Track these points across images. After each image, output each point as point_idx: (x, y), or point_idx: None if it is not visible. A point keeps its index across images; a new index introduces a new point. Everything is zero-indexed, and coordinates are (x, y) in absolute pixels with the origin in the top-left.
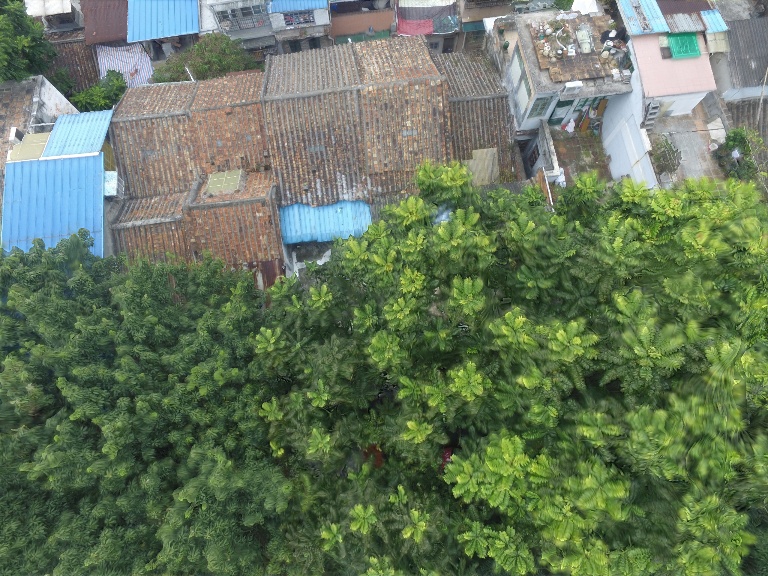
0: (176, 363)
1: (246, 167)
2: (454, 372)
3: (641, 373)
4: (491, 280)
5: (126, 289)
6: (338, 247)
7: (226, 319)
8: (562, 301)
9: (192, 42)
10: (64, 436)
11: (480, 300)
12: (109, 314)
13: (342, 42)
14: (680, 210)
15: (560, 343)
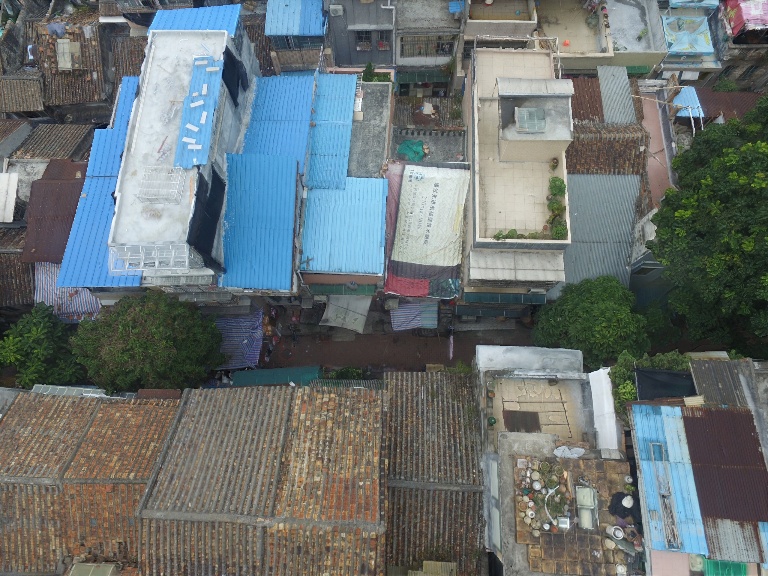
0: None
1: (123, 555)
2: None
3: None
4: None
5: None
6: None
7: None
8: None
9: None
10: None
11: None
12: None
13: (317, 292)
14: None
15: None
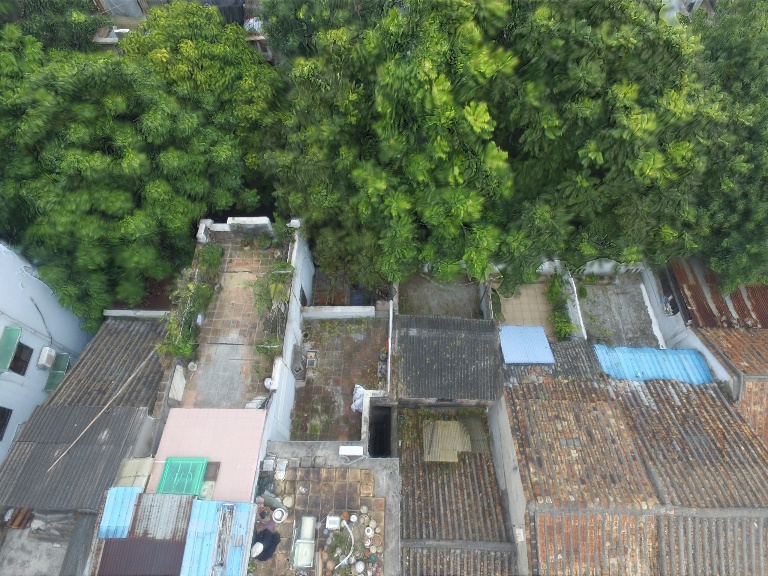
0: None
1: None
2: None
3: None
4: None
5: None
6: None
7: None
8: None
9: None
10: None
11: None
12: None
13: None
14: None
15: None
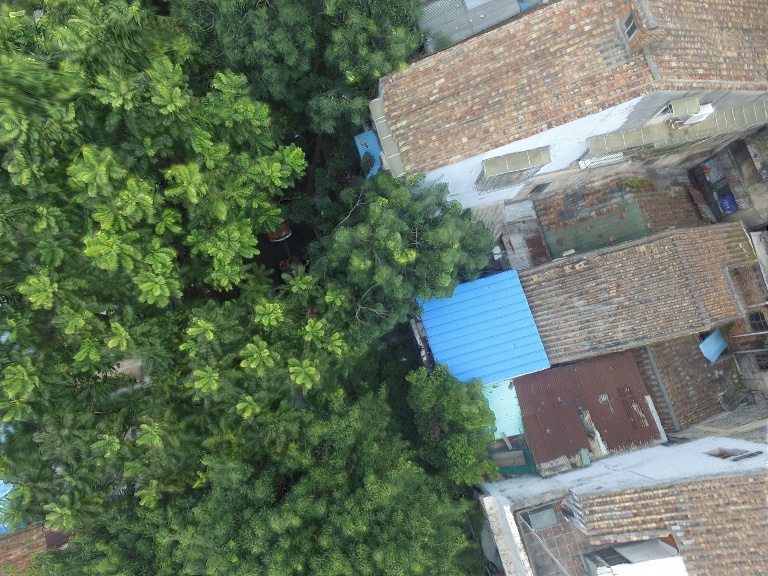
0: None
1: None
2: None
3: None
4: None
5: None
6: None
7: (47, 574)
8: None
9: None
10: None
11: None
12: None
13: None
14: None
15: None
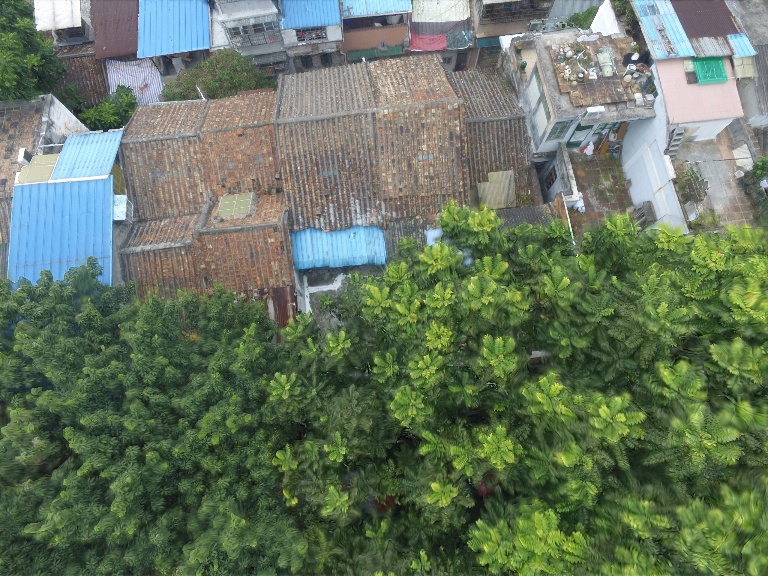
0: (187, 407)
1: (257, 189)
2: (483, 436)
3: (693, 459)
4: (520, 333)
5: (136, 329)
6: (355, 284)
7: (239, 360)
8: (597, 360)
9: (202, 56)
10: (71, 490)
11: (511, 361)
12: (118, 352)
13: (354, 57)
14: (723, 264)
15: (603, 420)
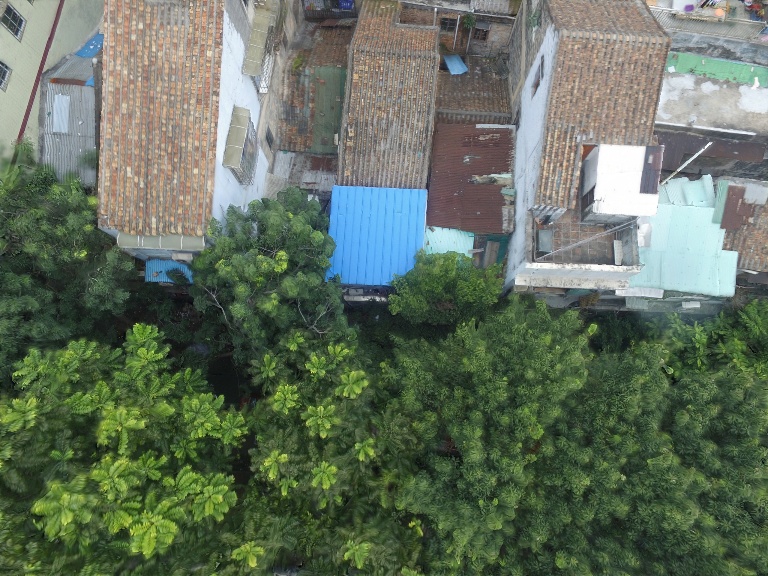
0: None
1: None
2: None
3: None
4: None
5: None
6: None
7: None
8: None
9: None
10: None
11: None
12: None
13: None
14: None
15: None
